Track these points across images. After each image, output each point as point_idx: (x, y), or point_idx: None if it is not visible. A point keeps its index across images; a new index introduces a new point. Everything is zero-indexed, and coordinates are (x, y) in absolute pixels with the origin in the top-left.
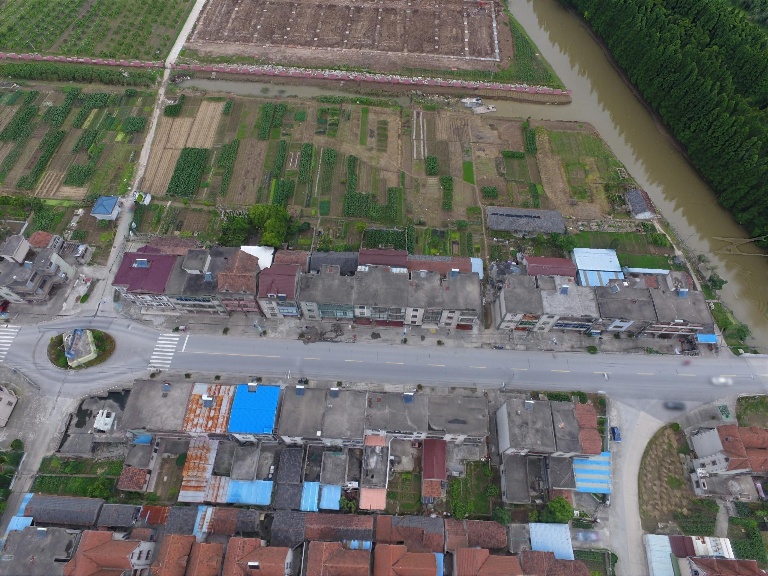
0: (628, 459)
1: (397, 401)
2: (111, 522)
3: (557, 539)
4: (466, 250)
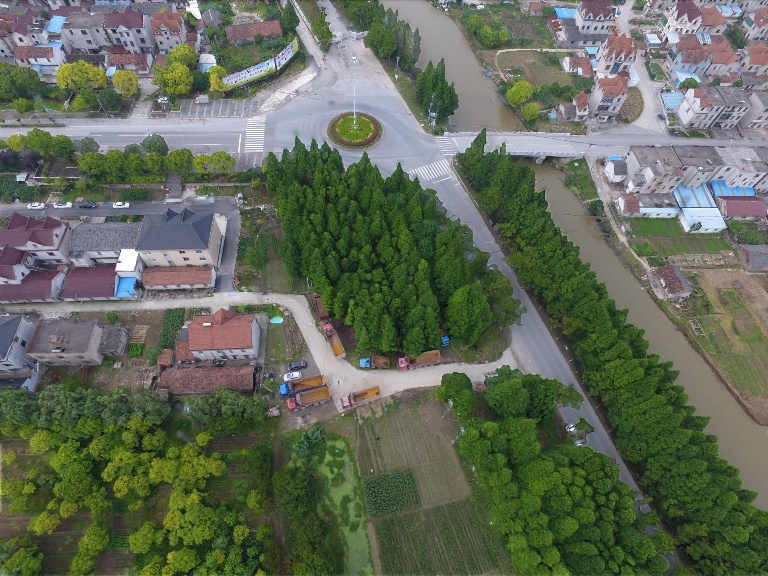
0: (651, 109)
1: None
2: None
3: None
4: None
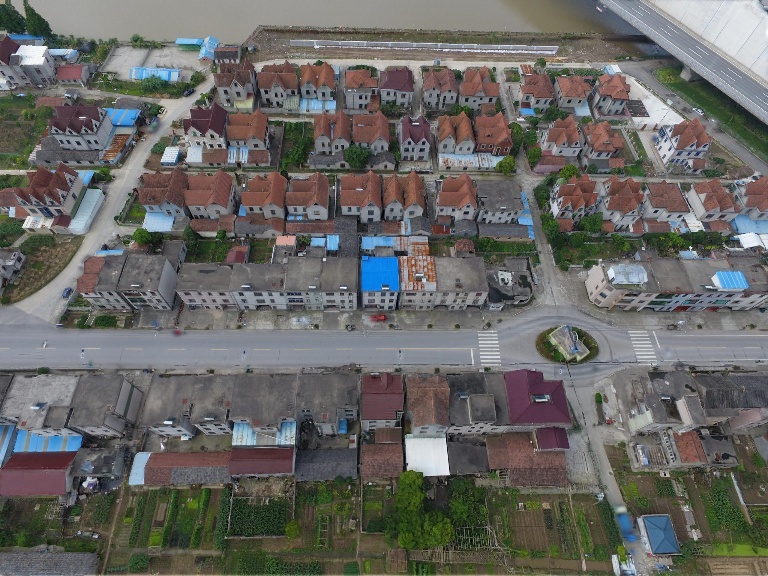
0: (68, 277)
1: (258, 285)
2: (466, 221)
3: (153, 223)
4: (147, 510)
